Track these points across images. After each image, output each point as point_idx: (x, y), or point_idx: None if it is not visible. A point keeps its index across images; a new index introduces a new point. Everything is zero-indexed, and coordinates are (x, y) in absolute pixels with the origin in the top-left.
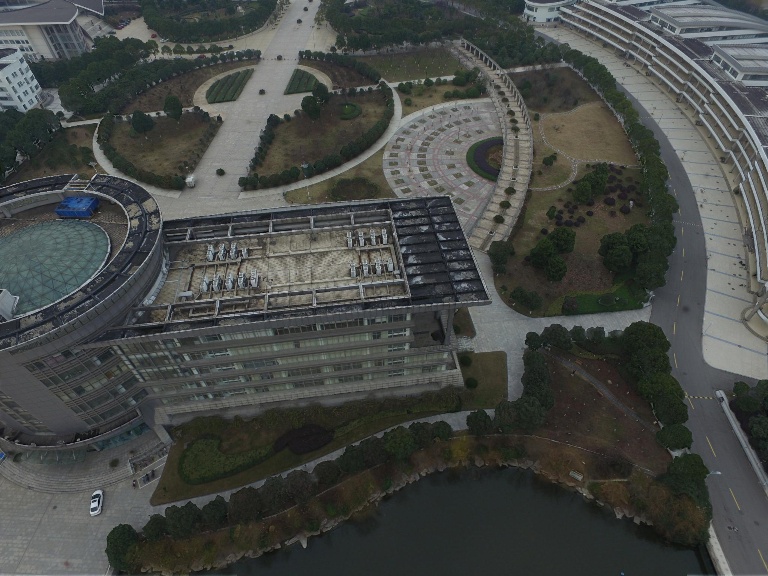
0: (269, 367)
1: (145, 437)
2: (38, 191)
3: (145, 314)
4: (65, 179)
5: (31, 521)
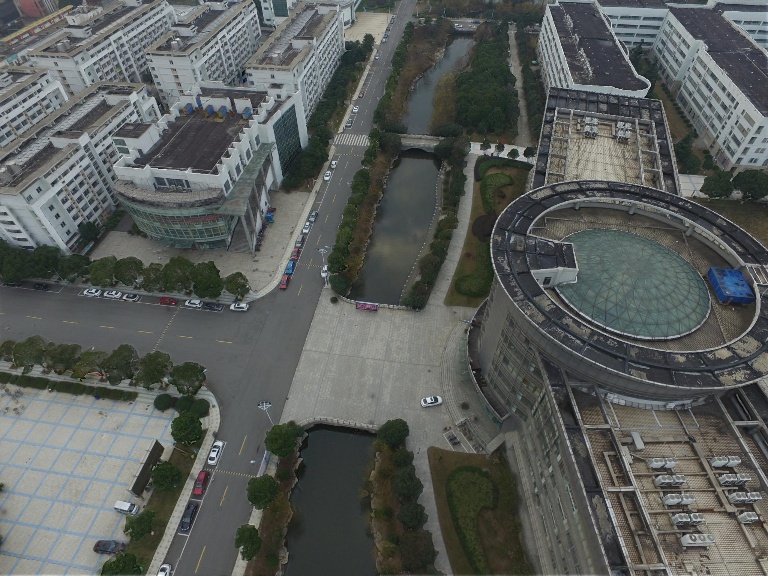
0: (574, 571)
1: (492, 427)
2: (731, 243)
3: (596, 399)
4: (766, 259)
5: (420, 358)
